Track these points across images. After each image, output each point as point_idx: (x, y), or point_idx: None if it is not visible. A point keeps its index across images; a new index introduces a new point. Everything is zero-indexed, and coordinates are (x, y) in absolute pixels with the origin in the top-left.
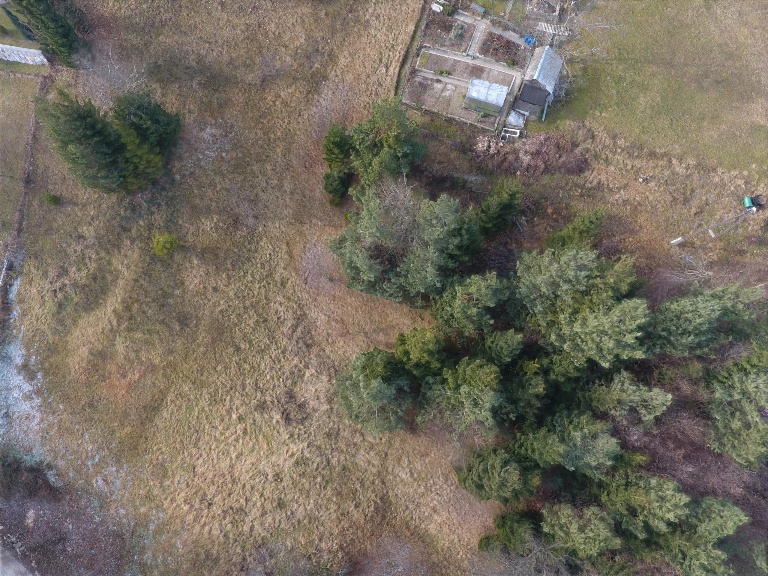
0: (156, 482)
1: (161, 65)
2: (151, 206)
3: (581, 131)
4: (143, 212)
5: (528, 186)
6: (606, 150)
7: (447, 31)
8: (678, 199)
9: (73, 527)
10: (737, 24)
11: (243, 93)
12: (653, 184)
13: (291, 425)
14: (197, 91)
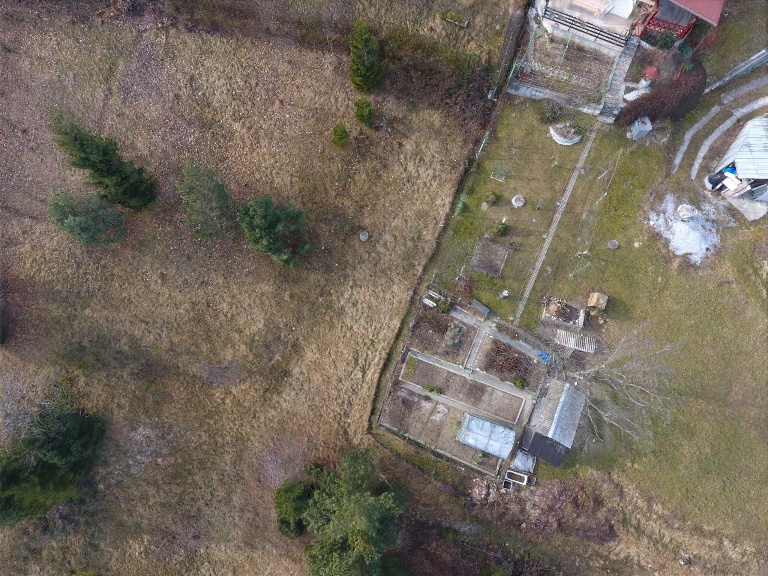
0: None
1: (86, 347)
2: (67, 524)
3: (606, 485)
4: (56, 533)
5: (536, 545)
6: (638, 513)
7: (441, 333)
8: None
9: None
10: None
11: (185, 387)
12: (698, 569)
13: None
14: (129, 382)
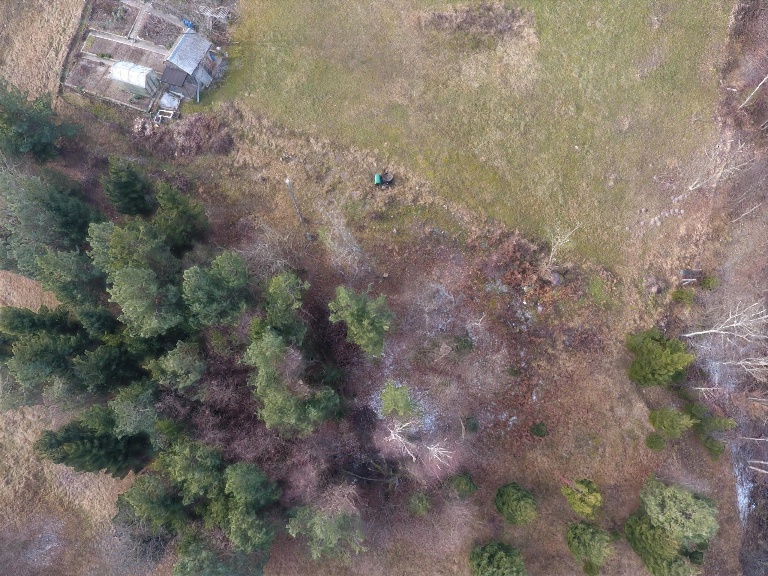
0: None
1: None
2: None
3: (230, 112)
4: None
5: (184, 167)
6: (253, 130)
7: (112, 15)
8: (312, 177)
9: None
10: (384, 6)
11: None
12: (292, 163)
13: None
14: None
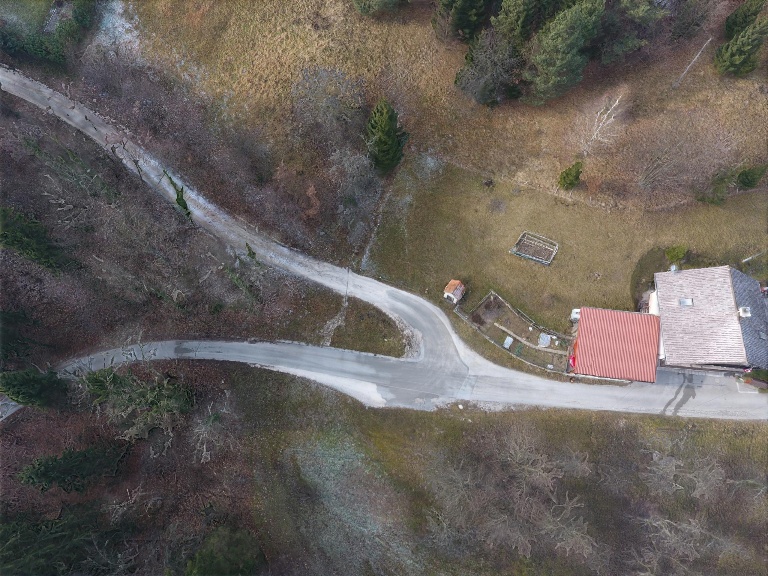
0: (226, 74)
1: None
2: None
3: None
4: None
5: None
6: None
7: None
8: None
9: (168, 110)
10: None
11: None
12: None
13: (319, 30)
14: None
